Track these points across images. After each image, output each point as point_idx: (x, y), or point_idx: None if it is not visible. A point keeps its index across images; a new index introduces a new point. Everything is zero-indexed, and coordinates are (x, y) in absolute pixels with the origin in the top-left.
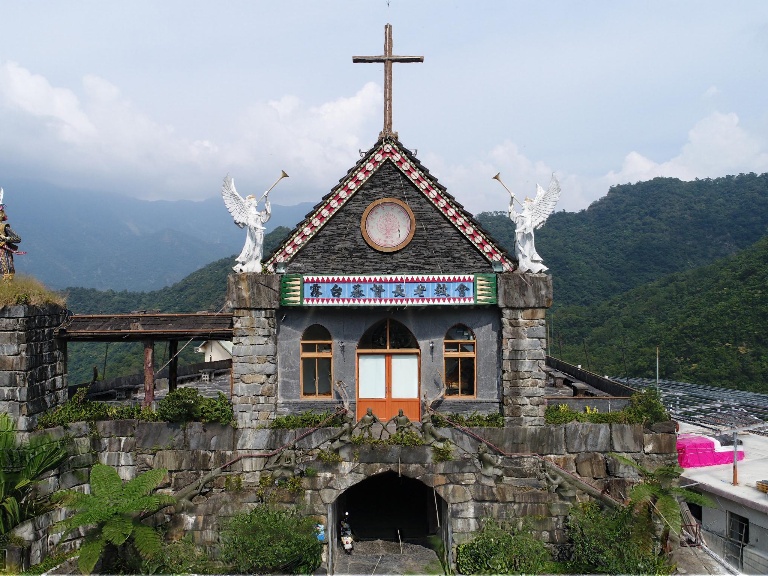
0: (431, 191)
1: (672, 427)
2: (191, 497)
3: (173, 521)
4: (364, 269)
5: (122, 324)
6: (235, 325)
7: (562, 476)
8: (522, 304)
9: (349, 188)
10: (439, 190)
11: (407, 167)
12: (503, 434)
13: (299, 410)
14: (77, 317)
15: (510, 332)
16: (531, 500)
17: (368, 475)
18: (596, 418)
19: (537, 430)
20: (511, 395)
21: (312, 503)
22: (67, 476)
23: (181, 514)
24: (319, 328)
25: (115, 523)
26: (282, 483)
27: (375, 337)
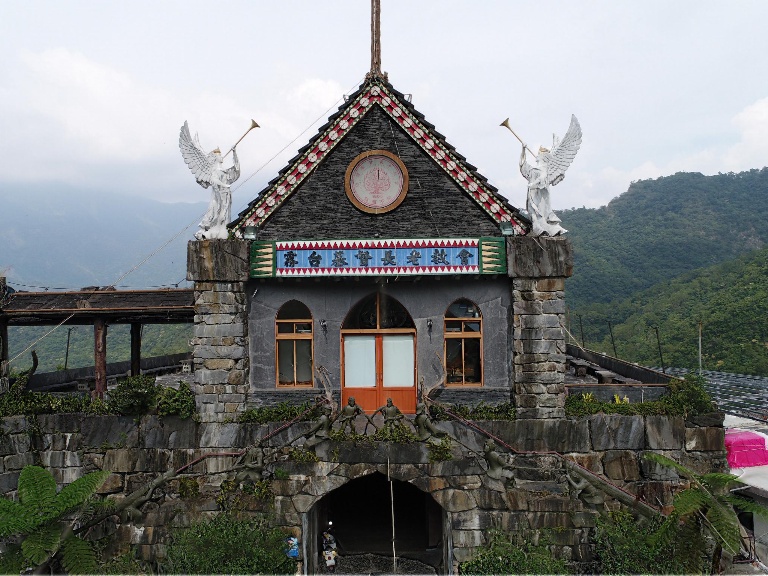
0: (427, 141)
1: (719, 419)
2: (139, 504)
3: (117, 533)
4: (349, 234)
5: (69, 302)
6: (196, 301)
7: (587, 479)
8: (536, 273)
9: (330, 139)
10: (436, 139)
11: (398, 113)
12: (515, 428)
13: (274, 401)
14: (19, 295)
15: (522, 306)
16: (549, 508)
17: (350, 478)
18: (627, 409)
19: (556, 423)
20: (524, 382)
21: (283, 512)
22: (1, 479)
23: (127, 525)
24: (297, 305)
25: (38, 537)
26: (247, 488)
27: (365, 316)
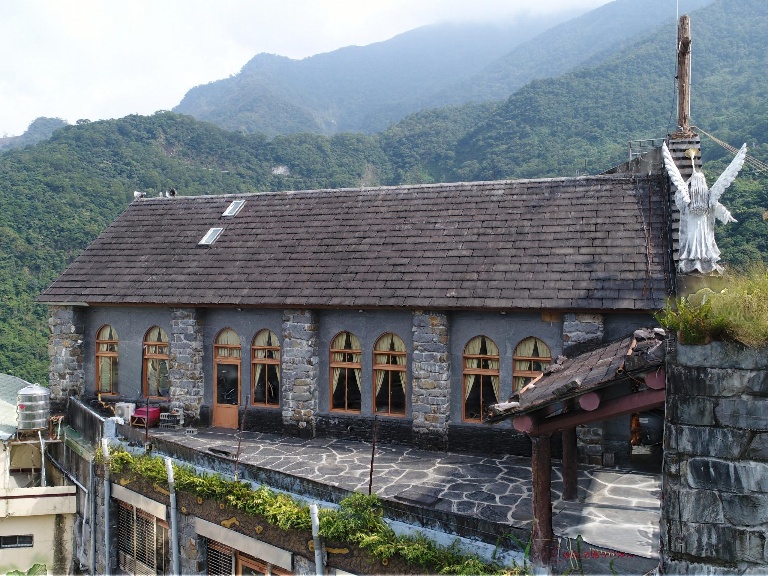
0: None
1: None
2: None
3: None
4: None
5: None
6: None
7: None
8: None
9: None
10: None
11: None
12: None
13: None
14: None
15: None
16: None
17: None
18: None
19: None
20: None
21: None
22: None
23: None
24: None
25: None
26: None
27: None
